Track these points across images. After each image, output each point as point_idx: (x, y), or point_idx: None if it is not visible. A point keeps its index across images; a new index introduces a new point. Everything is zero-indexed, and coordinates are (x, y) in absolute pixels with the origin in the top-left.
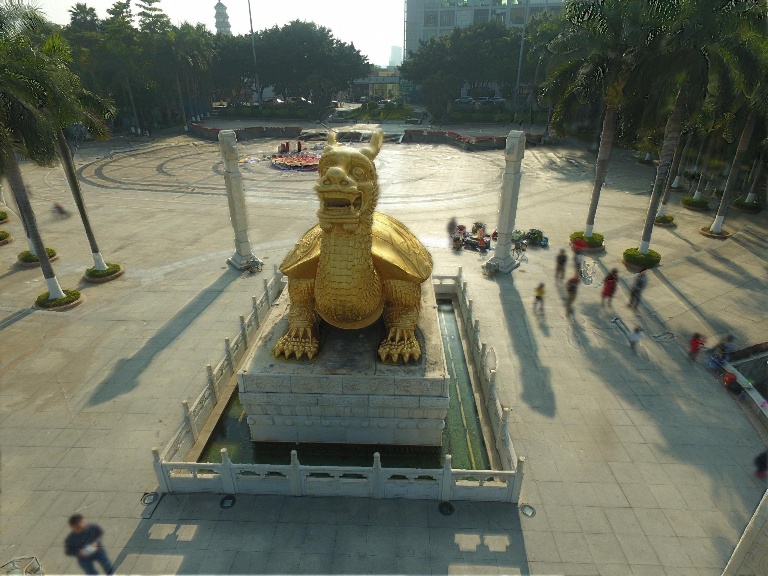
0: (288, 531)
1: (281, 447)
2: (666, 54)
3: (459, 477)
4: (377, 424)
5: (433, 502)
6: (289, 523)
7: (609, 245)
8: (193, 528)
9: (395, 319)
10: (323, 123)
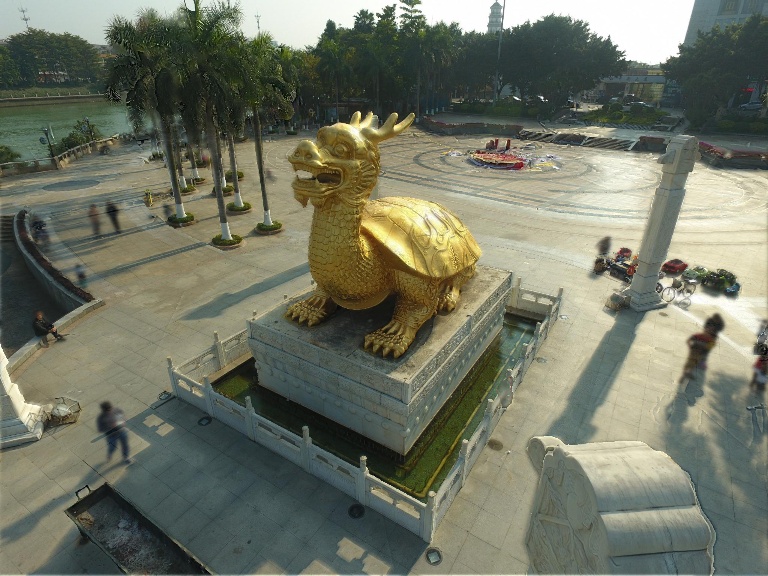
0: (223, 462)
1: (273, 397)
2: None
3: (372, 485)
4: (348, 408)
5: (350, 499)
6: (229, 457)
7: None
8: (170, 428)
9: (399, 312)
10: (552, 123)
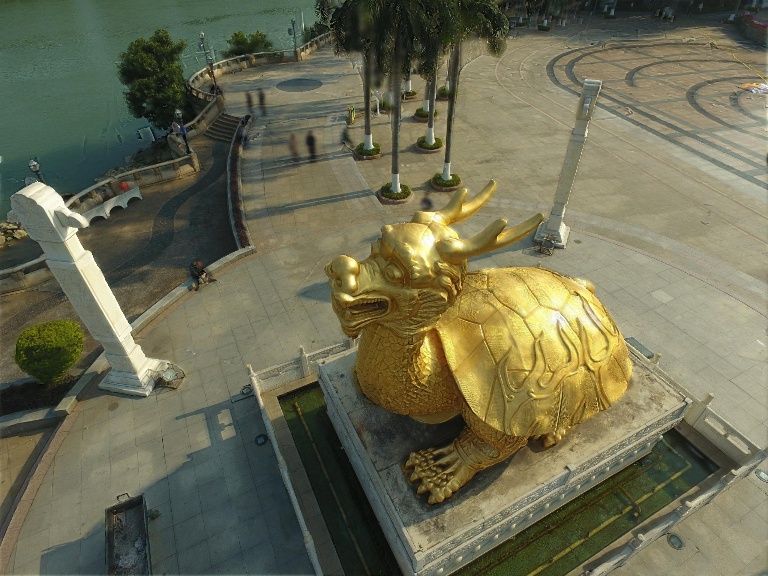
0: (251, 501)
1: (330, 438)
2: None
3: None
4: (378, 507)
5: None
6: (258, 497)
7: None
8: (233, 434)
9: (463, 440)
10: None
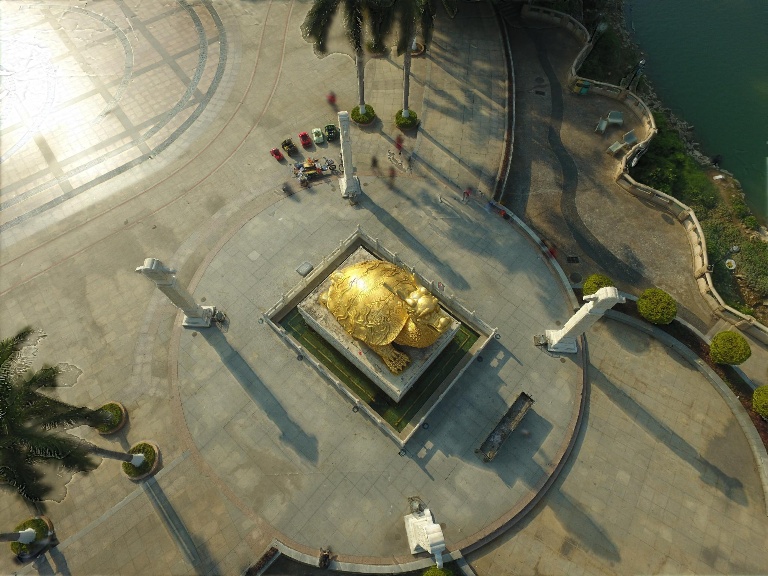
0: (453, 412)
1: None
2: (402, 2)
3: None
4: None
5: (475, 361)
6: (450, 410)
7: (374, 108)
8: (429, 442)
9: None
10: None
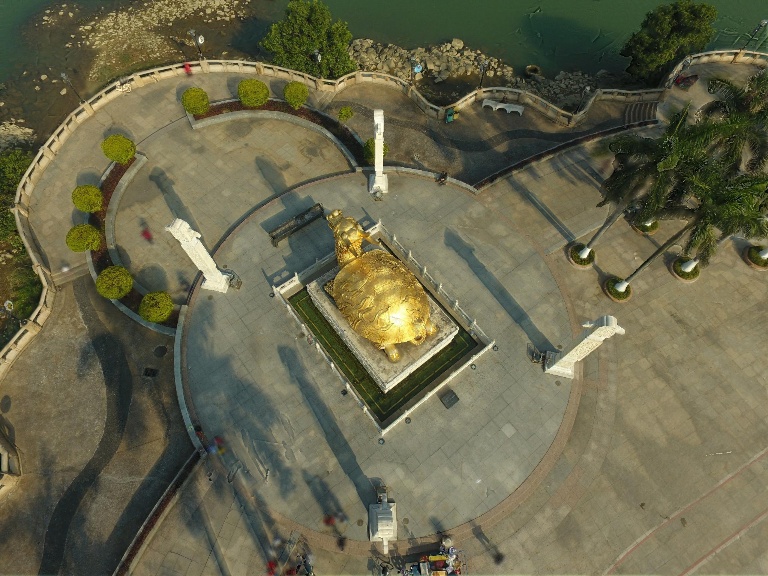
0: None
1: None
2: None
3: None
4: None
5: None
6: None
7: None
8: None
9: None
10: None
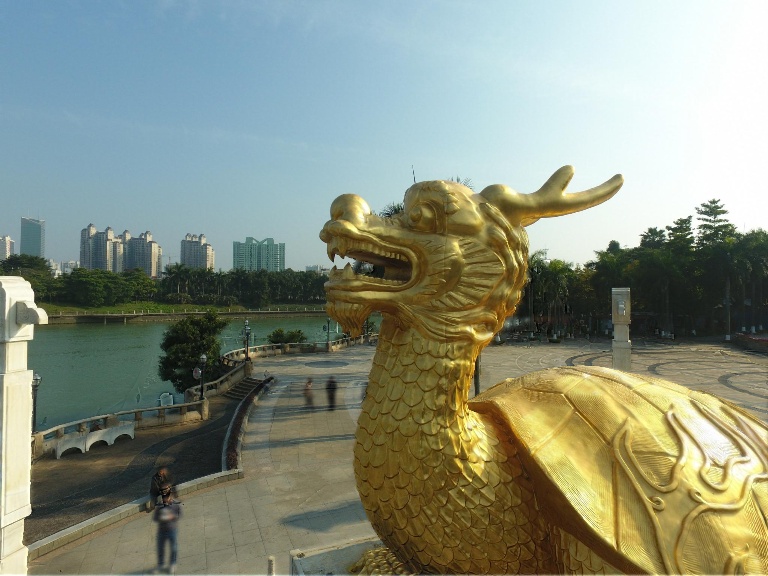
0: None
1: None
2: None
3: None
4: None
5: None
6: None
7: None
8: None
9: None
10: None
